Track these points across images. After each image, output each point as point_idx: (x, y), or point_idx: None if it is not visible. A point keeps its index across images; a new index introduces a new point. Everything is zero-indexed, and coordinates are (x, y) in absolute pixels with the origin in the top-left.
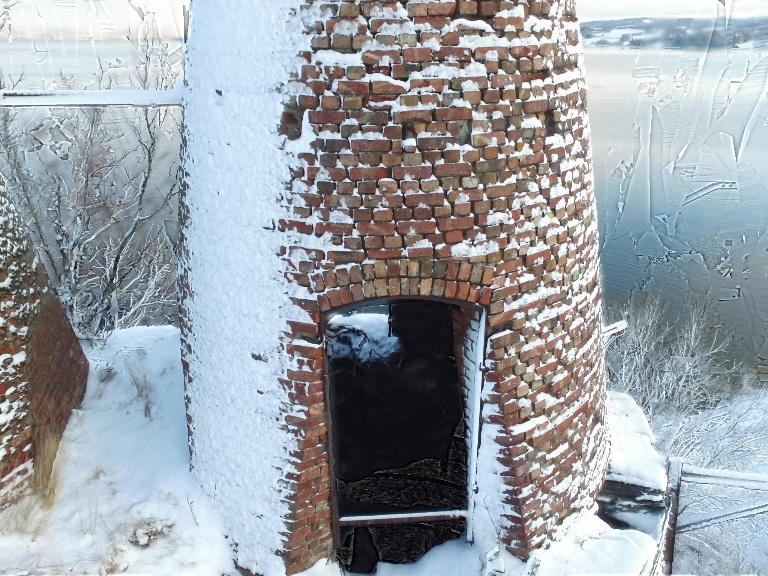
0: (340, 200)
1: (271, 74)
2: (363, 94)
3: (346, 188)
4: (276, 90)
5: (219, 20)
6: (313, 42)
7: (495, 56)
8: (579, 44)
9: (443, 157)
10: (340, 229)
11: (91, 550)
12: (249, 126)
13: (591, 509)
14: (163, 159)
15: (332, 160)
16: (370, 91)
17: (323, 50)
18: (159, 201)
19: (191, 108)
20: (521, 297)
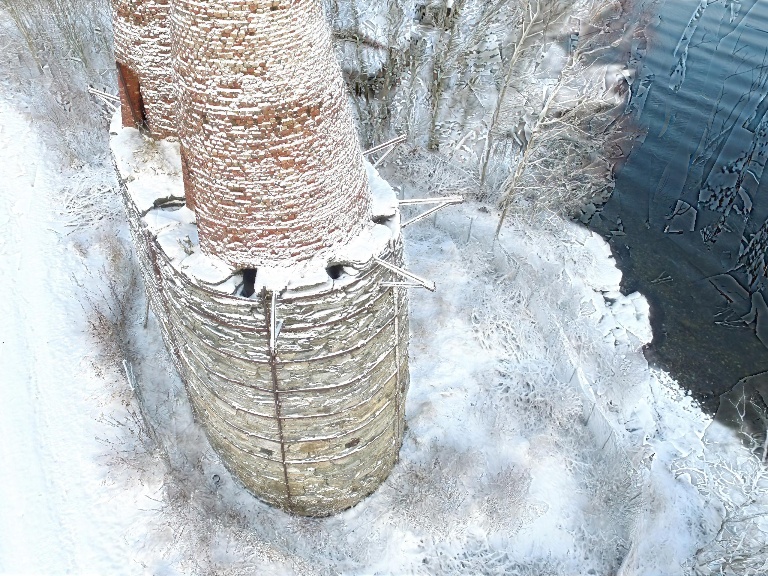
0: None
1: None
2: None
3: None
4: None
5: None
6: None
7: None
8: (239, 98)
9: None
10: None
11: (179, 166)
12: None
13: (228, 265)
14: (677, 7)
15: None
16: None
17: None
18: (625, 46)
19: None
20: None
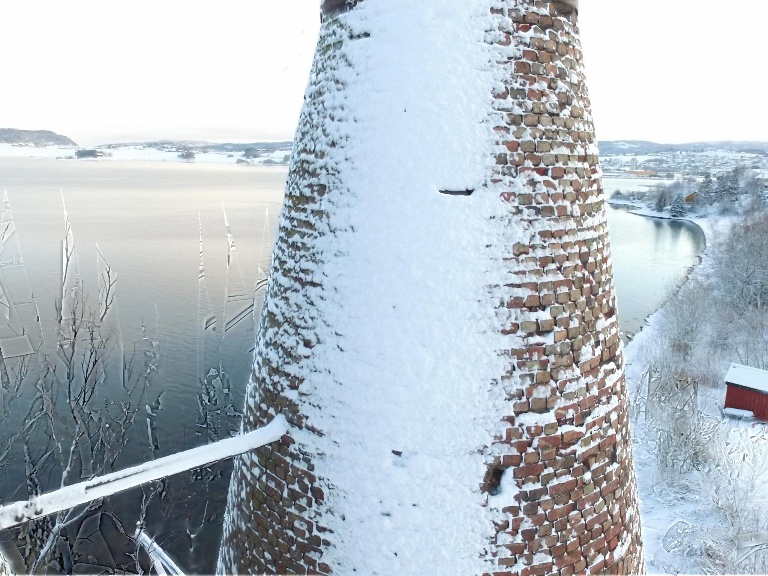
0: (541, 542)
1: (474, 438)
2: (557, 445)
3: (546, 530)
4: (478, 452)
5: (403, 387)
6: (515, 407)
7: None
8: None
9: (605, 480)
10: (542, 569)
11: None
12: (445, 487)
13: None
14: None
15: (534, 508)
16: (561, 441)
17: (525, 413)
18: None
19: (340, 463)
20: (639, 569)
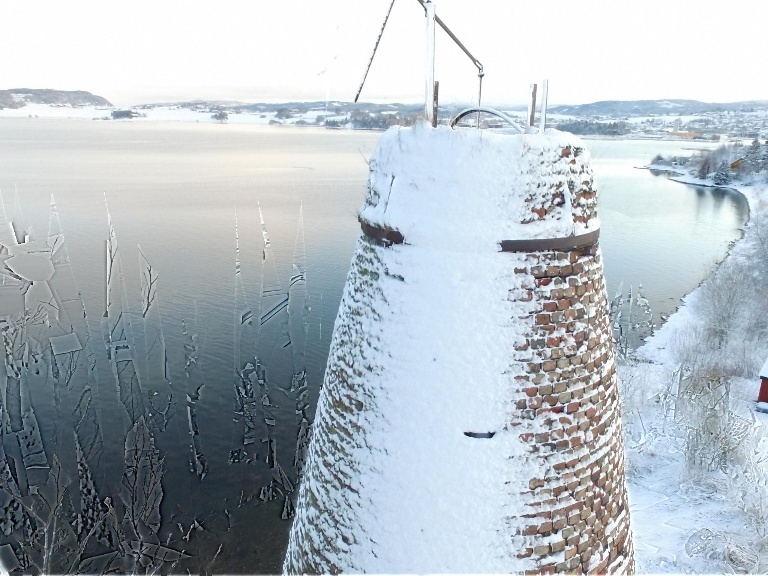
0: None
1: None
2: None
3: None
4: None
5: None
6: None
7: (626, 574)
8: None
9: None
10: None
11: None
12: None
13: None
14: None
15: None
16: None
17: None
18: None
19: None
20: None
